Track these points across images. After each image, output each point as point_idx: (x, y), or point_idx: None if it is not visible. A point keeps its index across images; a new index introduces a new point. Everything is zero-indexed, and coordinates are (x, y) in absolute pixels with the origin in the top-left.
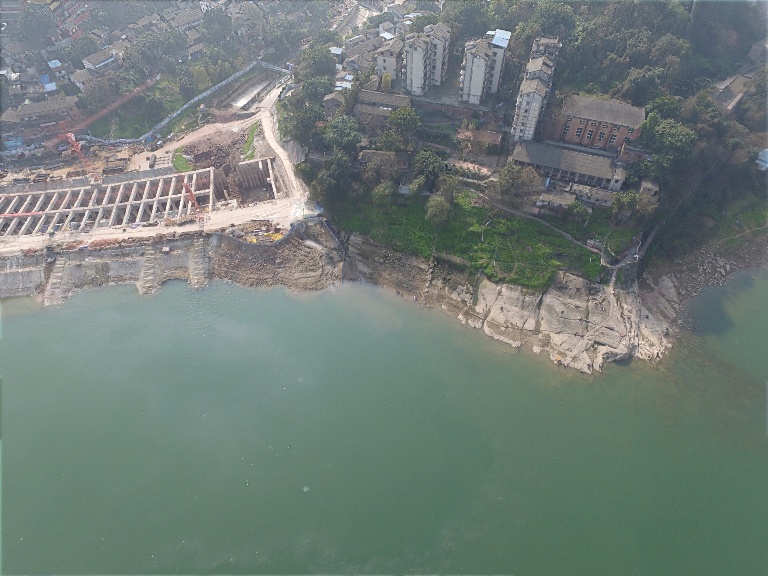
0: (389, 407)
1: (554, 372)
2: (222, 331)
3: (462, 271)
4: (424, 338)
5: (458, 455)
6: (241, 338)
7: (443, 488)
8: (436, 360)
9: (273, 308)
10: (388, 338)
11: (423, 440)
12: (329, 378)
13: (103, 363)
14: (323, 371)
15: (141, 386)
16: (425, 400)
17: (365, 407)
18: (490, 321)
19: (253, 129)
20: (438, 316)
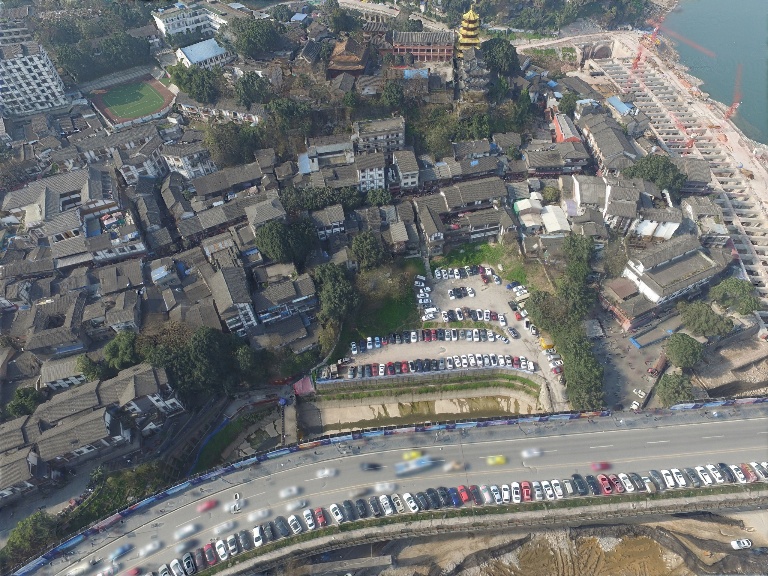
0: (726, 25)
1: (685, 0)
2: (713, 59)
3: (647, 3)
4: (683, 20)
5: (737, 14)
6: (715, 53)
7: (751, 18)
8: (695, 17)
9: (688, 50)
10: (689, 25)
11: (736, 19)
12: (721, 35)
13: (756, 88)
14: (719, 36)
15: (760, 76)
16: (718, 18)
17: (729, 29)
18: (668, 6)
19: (534, 52)
20: (669, 16)
